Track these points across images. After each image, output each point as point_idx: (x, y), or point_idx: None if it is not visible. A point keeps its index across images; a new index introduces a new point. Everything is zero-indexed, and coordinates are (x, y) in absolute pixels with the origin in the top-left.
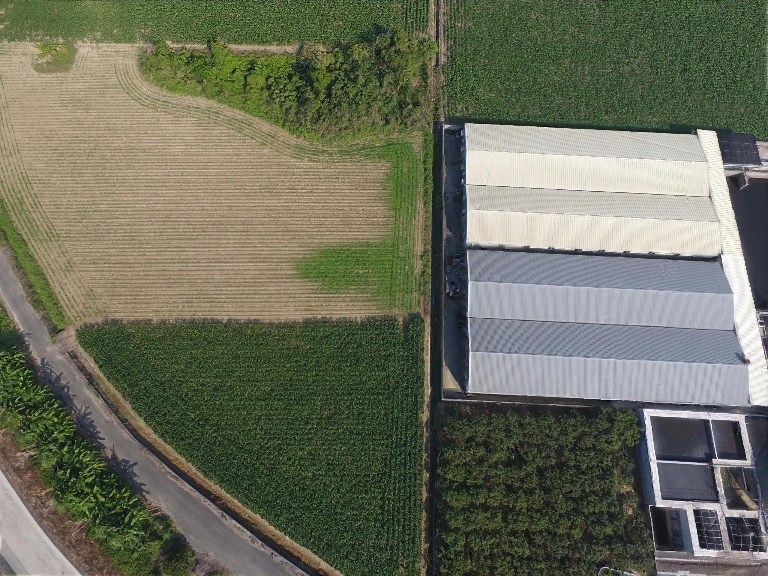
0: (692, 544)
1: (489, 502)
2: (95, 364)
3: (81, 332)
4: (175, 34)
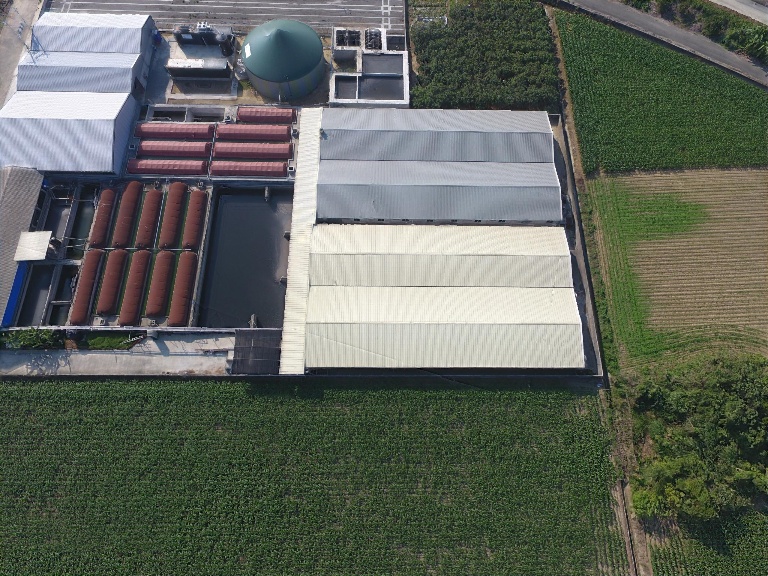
0: None
1: None
2: None
3: None
4: None
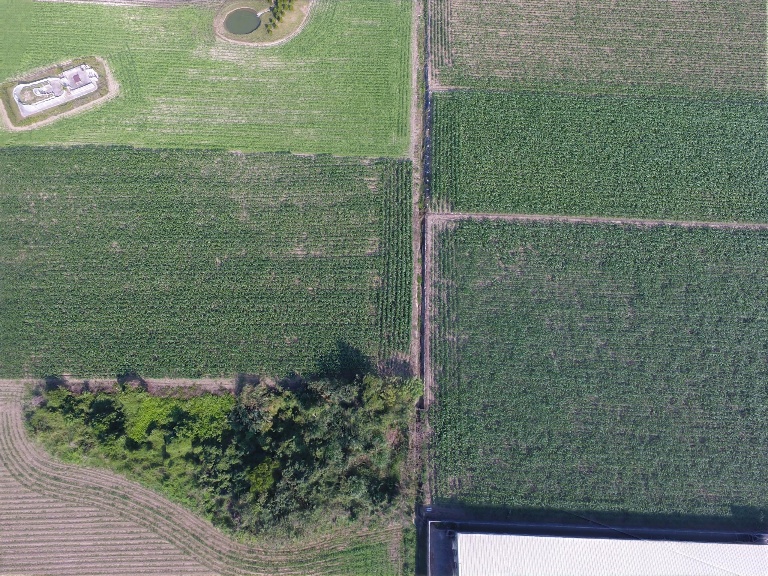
0: None
1: None
2: None
3: None
4: (75, 364)
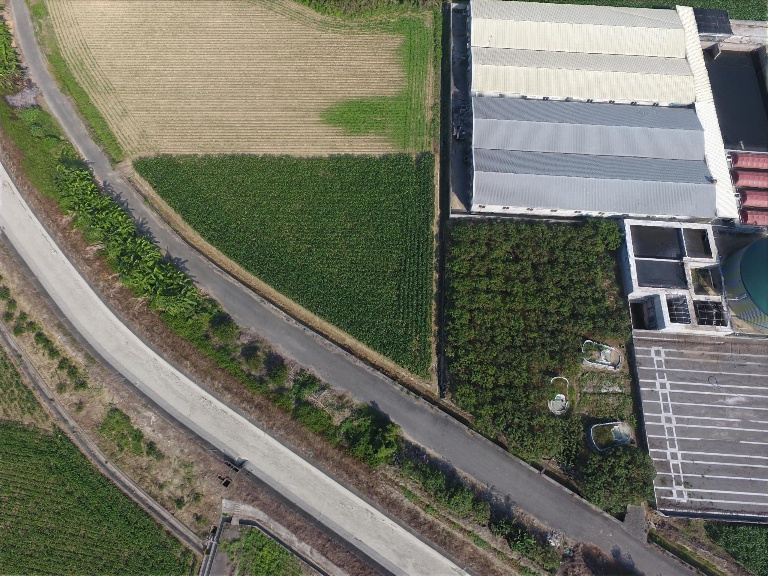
0: (664, 319)
1: (490, 288)
2: (150, 186)
3: (137, 161)
4: None
